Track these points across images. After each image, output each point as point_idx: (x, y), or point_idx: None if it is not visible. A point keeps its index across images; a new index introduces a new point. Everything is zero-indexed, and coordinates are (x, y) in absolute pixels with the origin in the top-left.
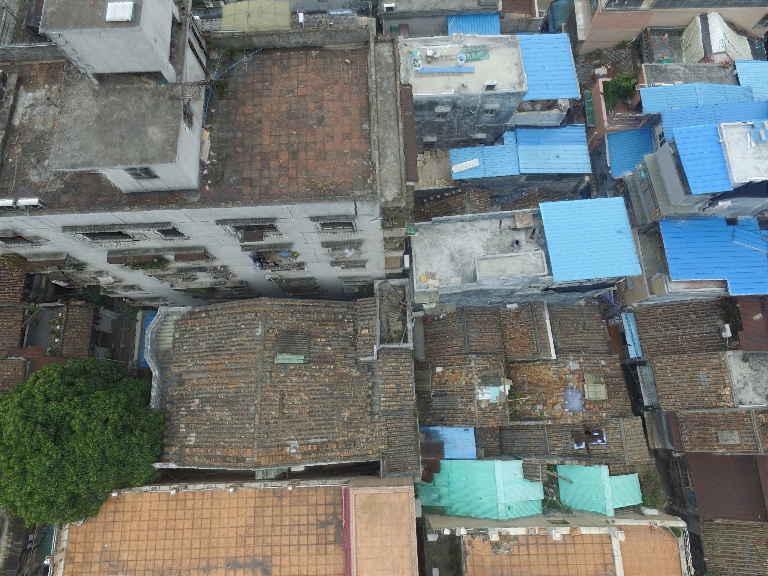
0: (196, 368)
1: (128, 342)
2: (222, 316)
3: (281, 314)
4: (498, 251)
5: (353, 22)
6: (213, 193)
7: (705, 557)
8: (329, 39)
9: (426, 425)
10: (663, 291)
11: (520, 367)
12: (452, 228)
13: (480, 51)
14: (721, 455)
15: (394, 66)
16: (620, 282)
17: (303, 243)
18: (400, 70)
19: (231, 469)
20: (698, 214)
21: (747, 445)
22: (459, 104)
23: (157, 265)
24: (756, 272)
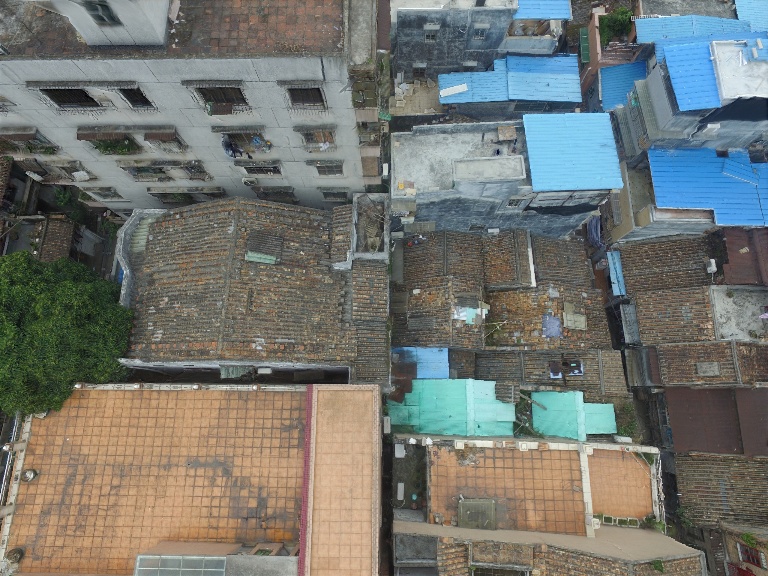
0: (167, 267)
1: (110, 266)
2: (196, 216)
3: (255, 214)
4: None
5: None
6: (179, 51)
7: (678, 492)
8: None
9: (400, 346)
10: (648, 221)
11: (500, 296)
12: (433, 140)
13: None
14: (700, 389)
15: None
16: (607, 219)
17: (275, 127)
18: None
19: (195, 362)
20: (687, 141)
21: (726, 376)
22: (448, 21)
23: (128, 148)
24: (744, 203)
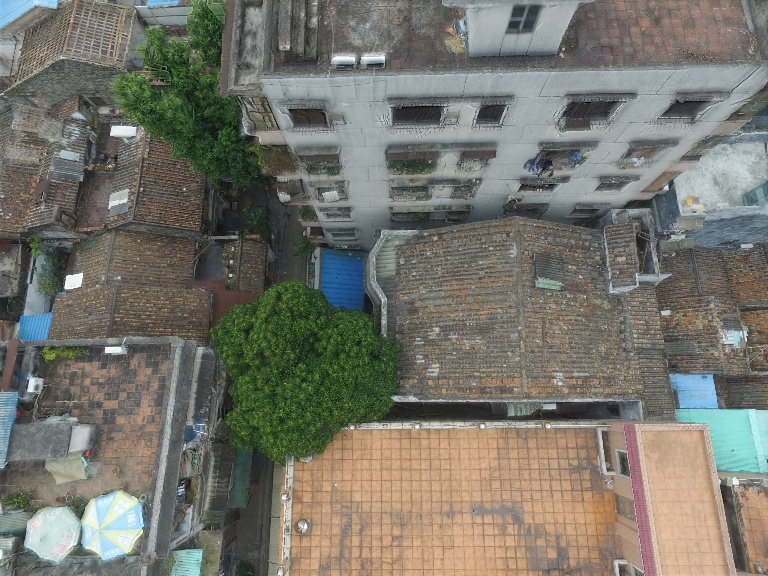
0: (433, 295)
1: None
2: (461, 238)
3: (534, 236)
4: (767, 176)
5: None
6: (569, 61)
7: None
8: None
9: None
10: None
11: (746, 315)
12: (711, 150)
13: None
14: None
15: None
16: None
17: (610, 142)
18: None
19: None
20: None
21: None
22: None
23: (429, 168)
24: None
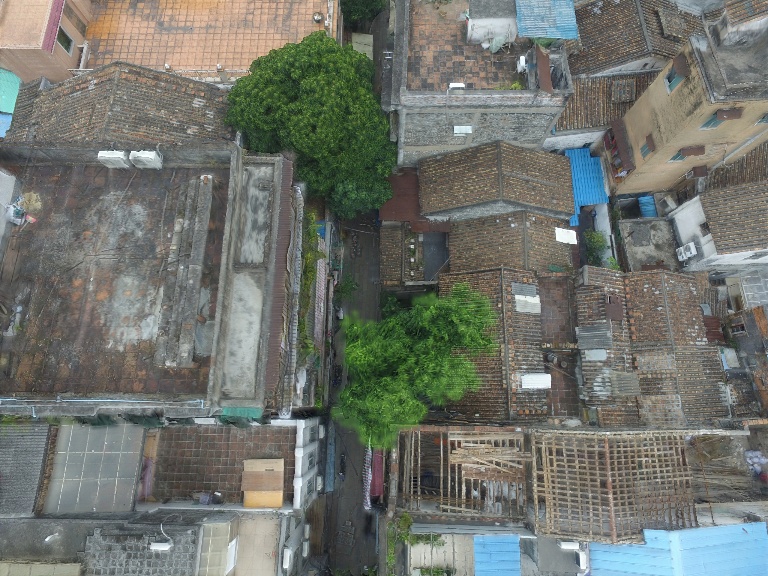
0: None
1: (376, 270)
2: None
3: None
4: None
5: None
6: None
7: None
8: None
9: None
10: None
11: None
12: None
13: None
14: None
15: None
16: None
17: None
18: None
19: (147, 68)
20: None
21: None
22: None
23: None
24: None
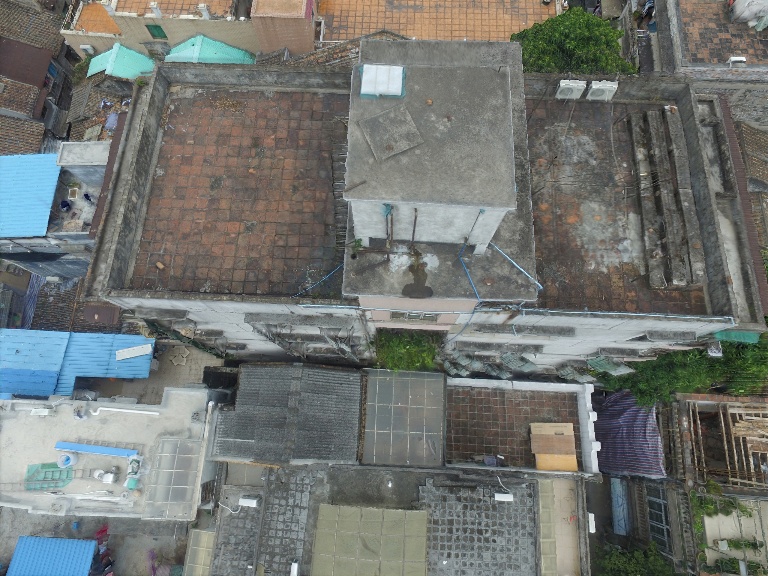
0: None
1: None
2: None
3: None
4: None
5: (215, 568)
6: None
7: None
8: None
9: None
10: None
11: None
12: None
13: (37, 481)
14: None
15: (100, 257)
16: None
17: None
18: (160, 454)
19: (408, 38)
20: None
21: None
22: None
23: None
24: None
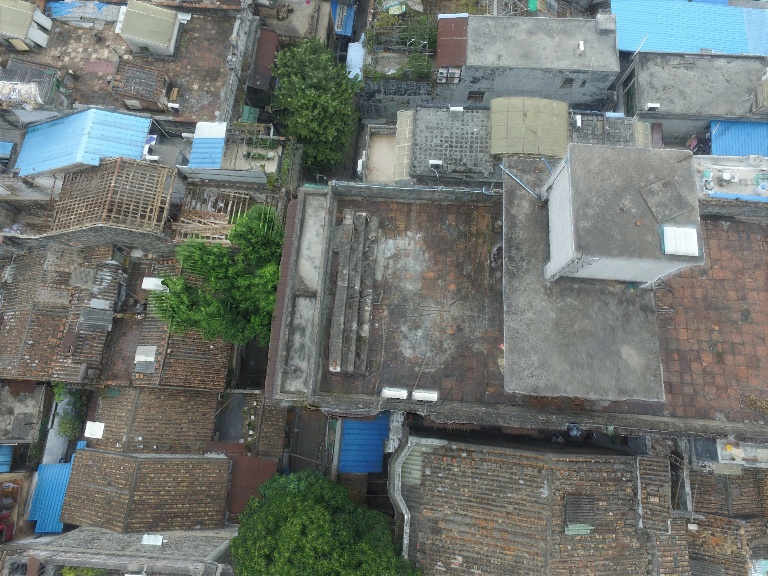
0: (458, 518)
1: (303, 426)
2: (491, 462)
3: (567, 473)
4: None
5: (631, 128)
6: None
7: None
8: (750, 212)
9: None
10: None
11: None
12: None
13: None
14: None
15: None
16: None
17: None
18: None
19: None
20: None
21: None
22: None
23: None
24: None
